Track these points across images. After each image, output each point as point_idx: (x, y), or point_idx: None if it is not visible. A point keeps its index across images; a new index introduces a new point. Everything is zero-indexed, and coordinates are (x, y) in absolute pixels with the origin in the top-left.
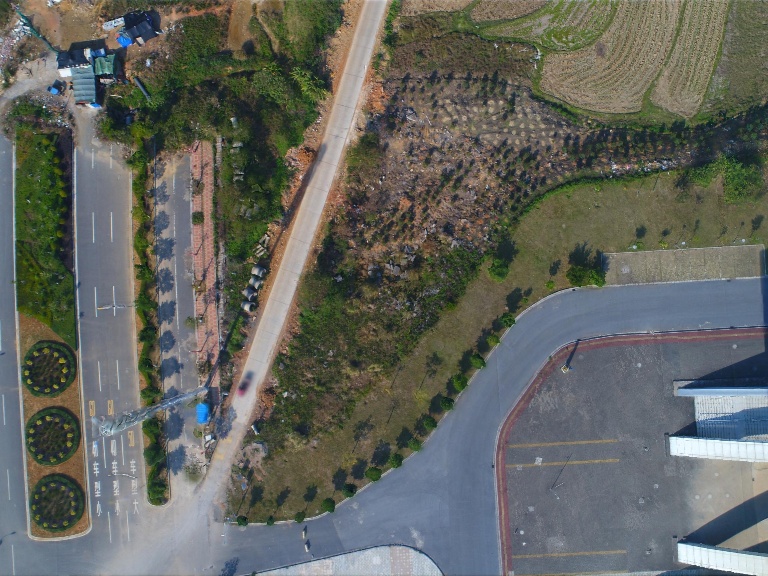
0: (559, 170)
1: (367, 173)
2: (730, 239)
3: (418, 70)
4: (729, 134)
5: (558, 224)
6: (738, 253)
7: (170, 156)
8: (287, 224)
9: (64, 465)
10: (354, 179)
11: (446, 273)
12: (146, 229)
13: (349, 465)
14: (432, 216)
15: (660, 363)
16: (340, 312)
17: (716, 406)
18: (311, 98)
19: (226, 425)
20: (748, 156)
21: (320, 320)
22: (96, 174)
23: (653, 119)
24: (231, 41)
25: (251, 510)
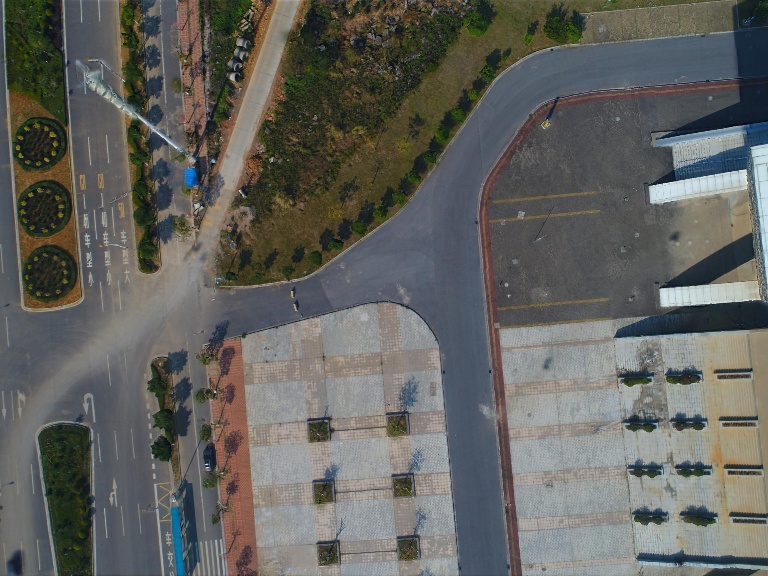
0: None
1: None
2: None
3: None
4: None
5: None
6: (711, 9)
7: None
8: None
9: (56, 237)
10: None
11: (427, 37)
12: (133, 5)
13: (335, 217)
14: None
15: (638, 116)
16: (324, 78)
17: (693, 152)
18: None
19: (214, 192)
20: None
21: (304, 86)
22: None
23: None
24: None
25: (240, 273)
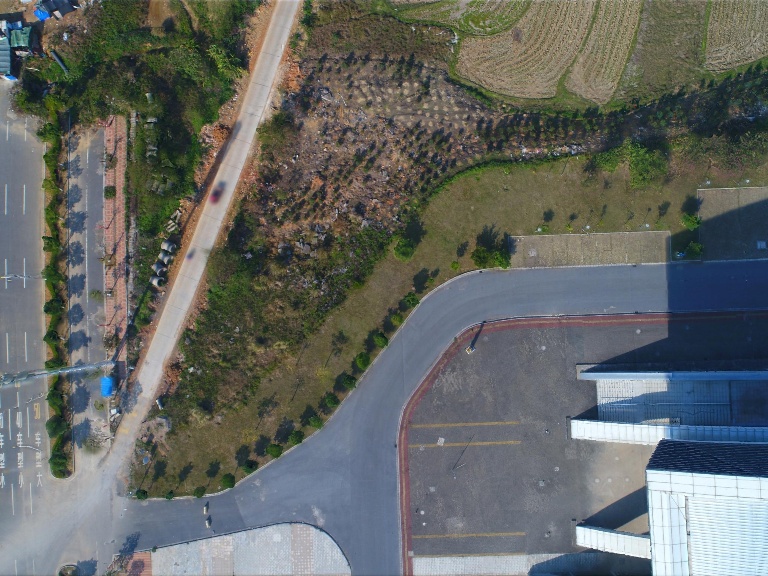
0: (470, 152)
1: (280, 151)
2: (637, 225)
3: (335, 51)
4: (640, 121)
5: (467, 206)
6: (644, 239)
7: (84, 130)
8: (199, 200)
9: None
10: (267, 157)
11: (354, 252)
12: (57, 202)
13: (249, 441)
14: (344, 196)
15: (564, 346)
16: (248, 289)
17: (617, 390)
18: (227, 76)
19: (131, 399)
20: (656, 143)
21: (228, 296)
22: (10, 146)
23: (567, 105)
24: (152, 18)
25: (154, 485)
